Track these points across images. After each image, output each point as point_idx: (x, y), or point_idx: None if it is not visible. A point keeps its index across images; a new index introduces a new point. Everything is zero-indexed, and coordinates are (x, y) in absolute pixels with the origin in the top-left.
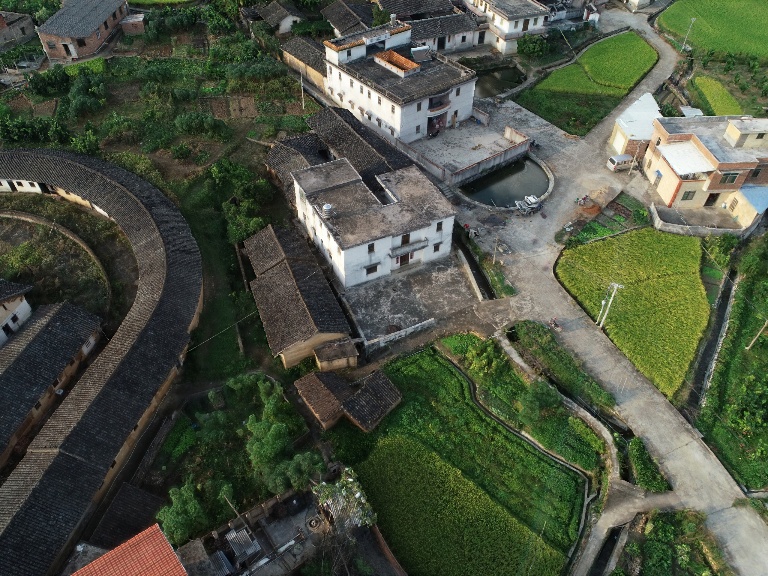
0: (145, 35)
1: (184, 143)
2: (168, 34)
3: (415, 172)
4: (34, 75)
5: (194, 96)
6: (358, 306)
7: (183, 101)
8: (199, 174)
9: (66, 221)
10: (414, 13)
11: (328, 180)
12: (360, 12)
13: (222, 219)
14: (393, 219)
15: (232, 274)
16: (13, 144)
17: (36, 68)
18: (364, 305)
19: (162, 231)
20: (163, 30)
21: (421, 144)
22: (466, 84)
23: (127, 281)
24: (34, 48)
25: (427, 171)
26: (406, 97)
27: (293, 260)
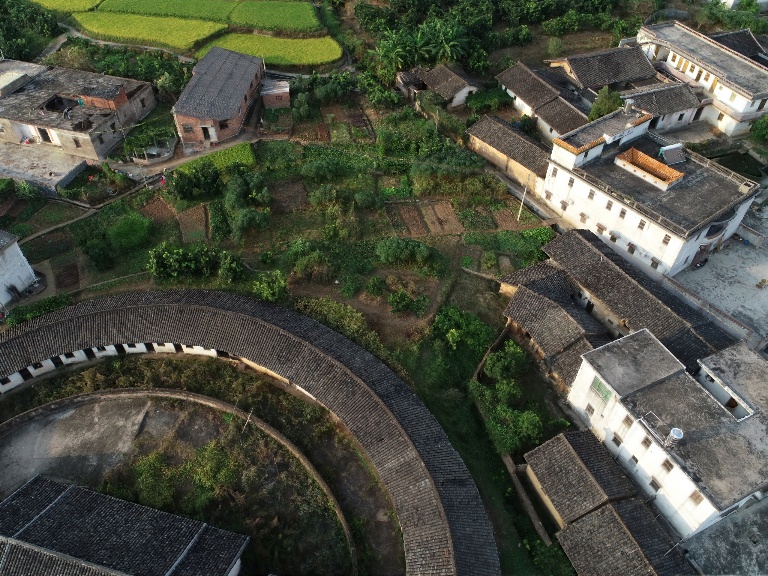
0: (296, 112)
1: (390, 280)
2: (317, 106)
3: (750, 354)
4: (179, 175)
5: (381, 204)
6: (714, 573)
7: (364, 208)
8: (425, 333)
9: (261, 408)
10: (613, 81)
11: (641, 371)
12: (548, 80)
13: (470, 405)
14: (764, 447)
15: (507, 501)
16: (168, 279)
17: (169, 157)
18: (722, 571)
19: (418, 447)
20: (311, 102)
21: (687, 278)
22: (747, 201)
23: (366, 514)
24: (165, 131)
25: (715, 324)
26: (693, 228)
27: (616, 501)
